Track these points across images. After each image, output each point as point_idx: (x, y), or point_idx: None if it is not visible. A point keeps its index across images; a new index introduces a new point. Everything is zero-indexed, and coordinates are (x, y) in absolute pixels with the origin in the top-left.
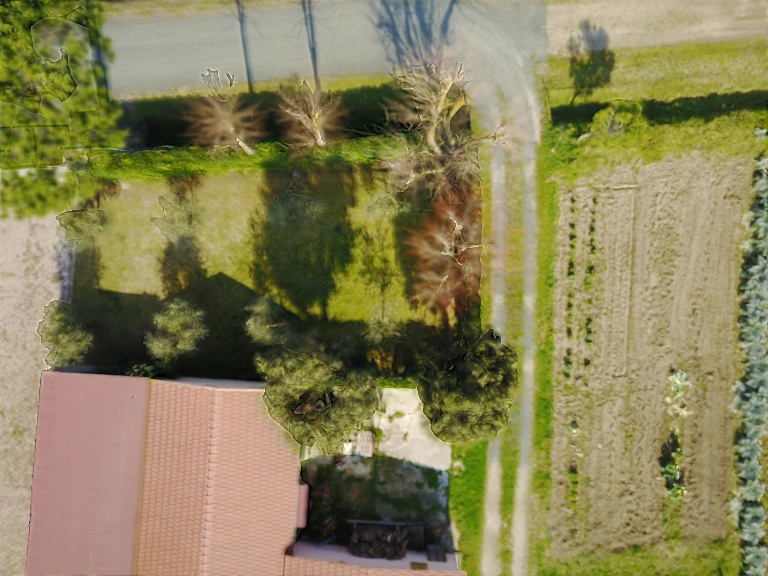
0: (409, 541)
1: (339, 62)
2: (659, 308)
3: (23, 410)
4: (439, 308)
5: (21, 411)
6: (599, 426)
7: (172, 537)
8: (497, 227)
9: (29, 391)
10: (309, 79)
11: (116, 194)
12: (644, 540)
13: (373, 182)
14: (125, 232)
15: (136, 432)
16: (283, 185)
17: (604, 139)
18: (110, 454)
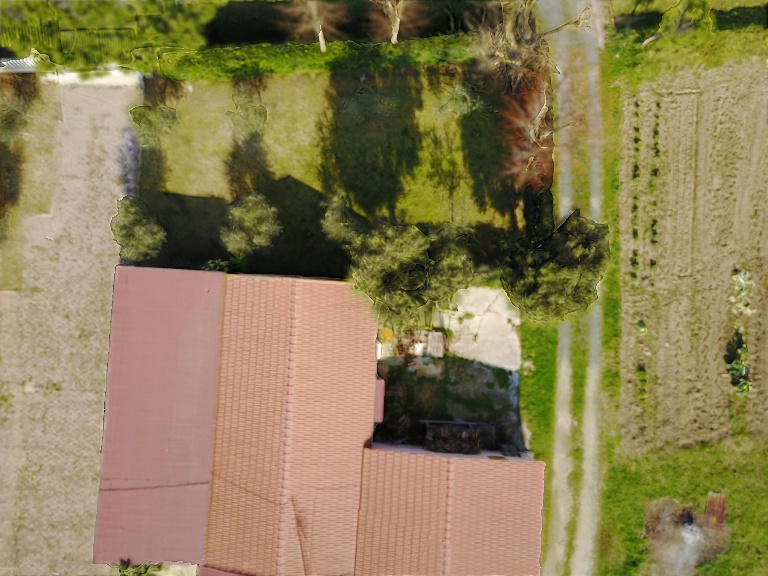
0: (481, 440)
1: None
2: (722, 209)
3: (89, 314)
4: (508, 210)
5: (87, 315)
6: (666, 325)
7: (251, 430)
8: (564, 131)
9: (95, 295)
10: None
11: (183, 97)
12: (711, 436)
13: (441, 87)
14: (192, 135)
15: (212, 327)
16: (351, 89)
17: (668, 44)
18: (186, 349)
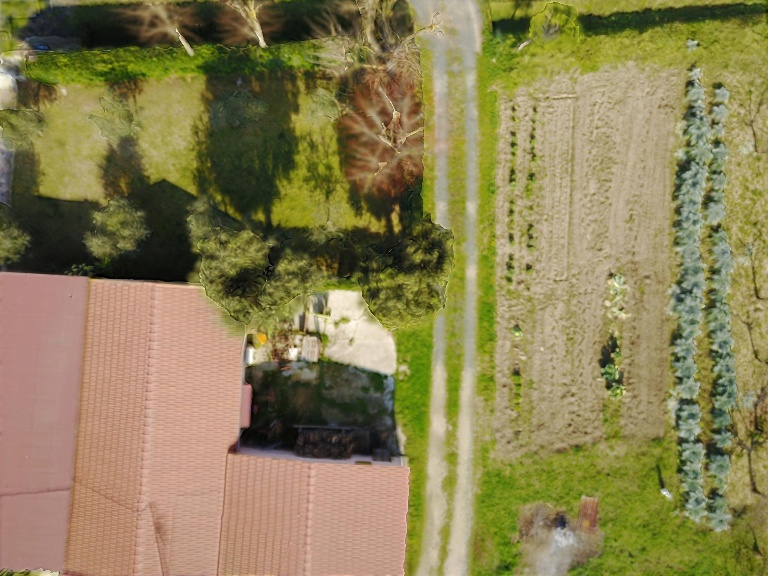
0: (354, 445)
1: None
2: (598, 214)
3: None
4: (384, 215)
5: None
6: (541, 329)
7: (111, 436)
8: (440, 135)
9: None
10: None
11: (57, 101)
12: (585, 440)
13: (318, 91)
14: (66, 139)
15: (74, 332)
16: (228, 93)
17: None
18: (47, 354)
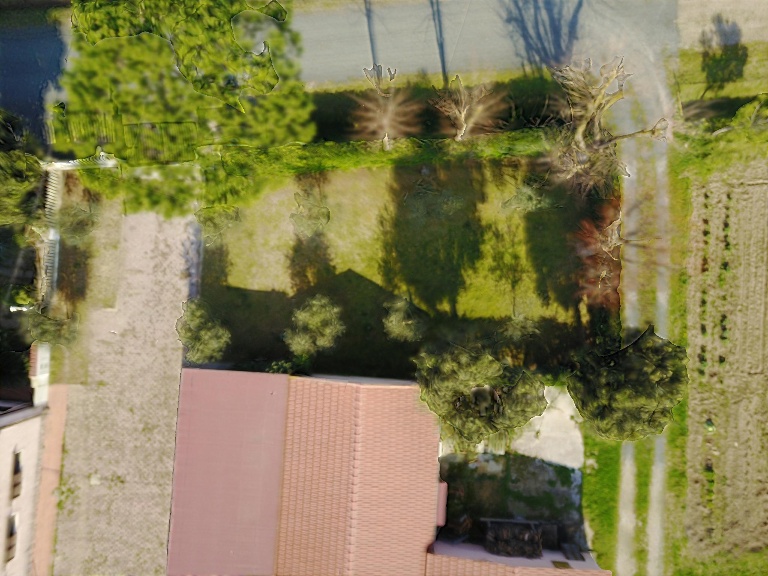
0: (543, 540)
1: (467, 58)
2: None
3: (152, 407)
4: (571, 305)
5: (150, 408)
6: (735, 424)
7: (315, 535)
8: (629, 223)
9: (158, 388)
10: (437, 75)
11: (244, 191)
12: None
13: (503, 178)
14: (253, 229)
15: (276, 429)
16: (412, 181)
17: (740, 134)
18: (250, 451)
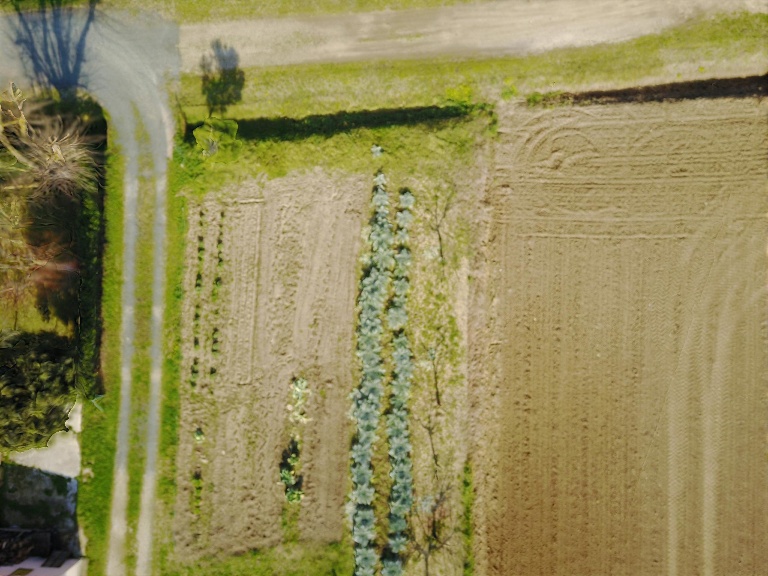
0: (35, 547)
1: None
2: (282, 318)
3: None
4: (70, 319)
5: None
6: (223, 433)
7: None
8: (128, 240)
9: None
10: None
11: None
12: (263, 543)
13: None
14: None
15: None
16: None
17: None
18: None
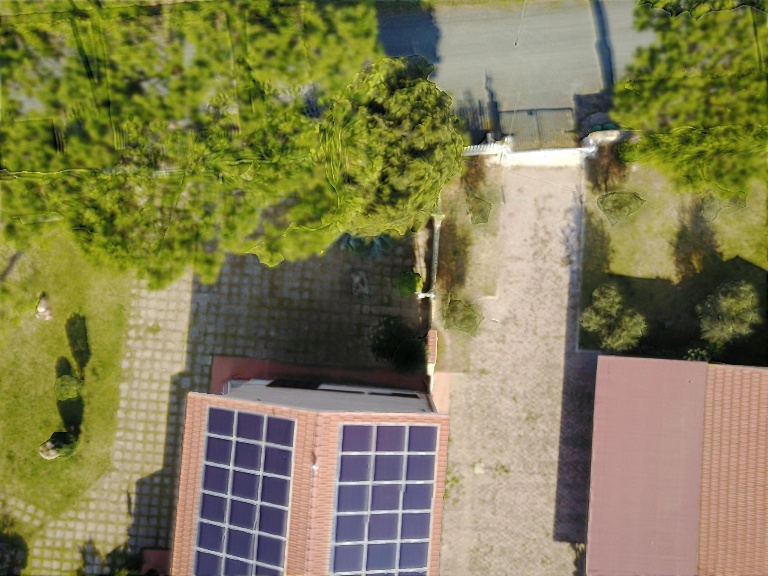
0: None
1: None
2: None
3: (535, 396)
4: None
5: (533, 397)
6: None
7: (745, 526)
8: None
9: (541, 377)
10: None
11: (625, 177)
12: None
13: None
14: (635, 216)
15: (696, 418)
16: None
17: None
18: (669, 440)
